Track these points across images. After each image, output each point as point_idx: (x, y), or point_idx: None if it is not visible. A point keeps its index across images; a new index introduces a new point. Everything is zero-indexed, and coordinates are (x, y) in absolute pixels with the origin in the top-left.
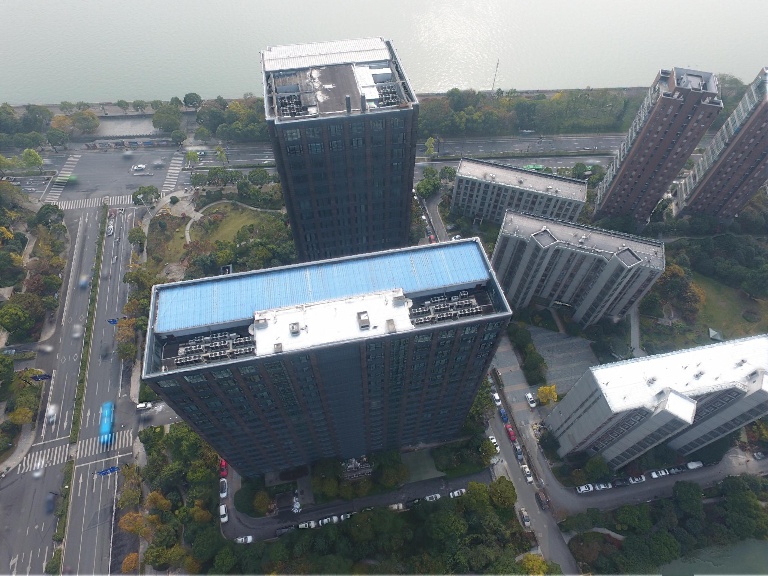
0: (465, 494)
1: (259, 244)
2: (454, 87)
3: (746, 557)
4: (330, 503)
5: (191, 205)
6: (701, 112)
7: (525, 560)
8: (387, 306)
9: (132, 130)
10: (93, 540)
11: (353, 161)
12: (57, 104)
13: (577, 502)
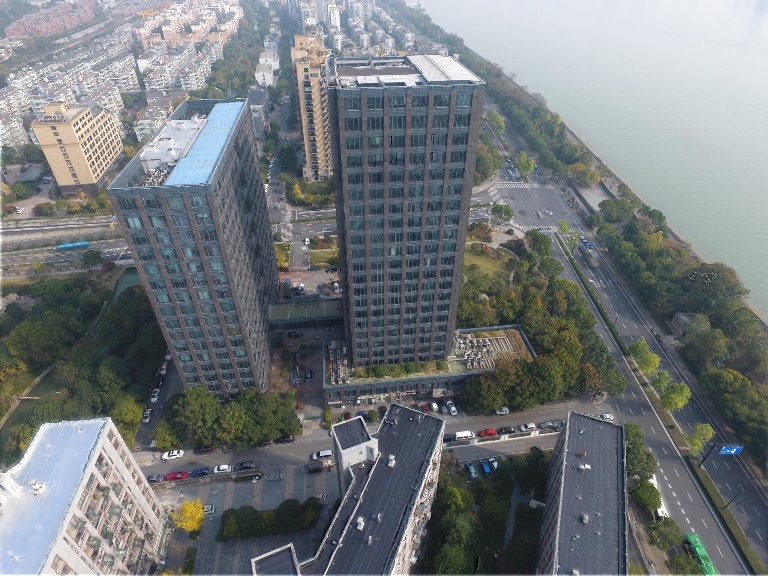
0: None
1: None
2: None
3: None
4: None
5: None
6: None
7: None
8: None
9: (596, 202)
10: None
11: None
12: (609, 167)
13: None
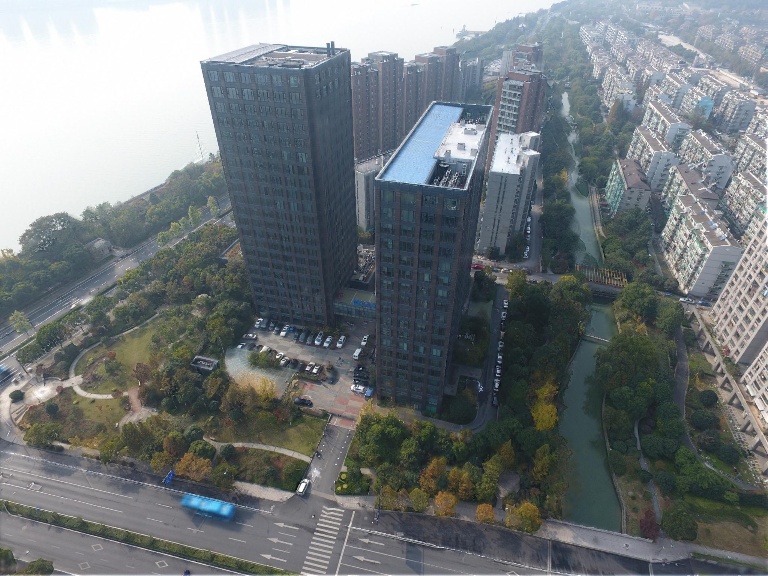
0: (515, 287)
1: (196, 327)
2: (173, 170)
3: (580, 224)
4: (484, 367)
5: (48, 382)
6: (371, 78)
7: (563, 280)
8: (463, 127)
9: None
10: (438, 570)
11: (336, 101)
12: None
13: (532, 262)
